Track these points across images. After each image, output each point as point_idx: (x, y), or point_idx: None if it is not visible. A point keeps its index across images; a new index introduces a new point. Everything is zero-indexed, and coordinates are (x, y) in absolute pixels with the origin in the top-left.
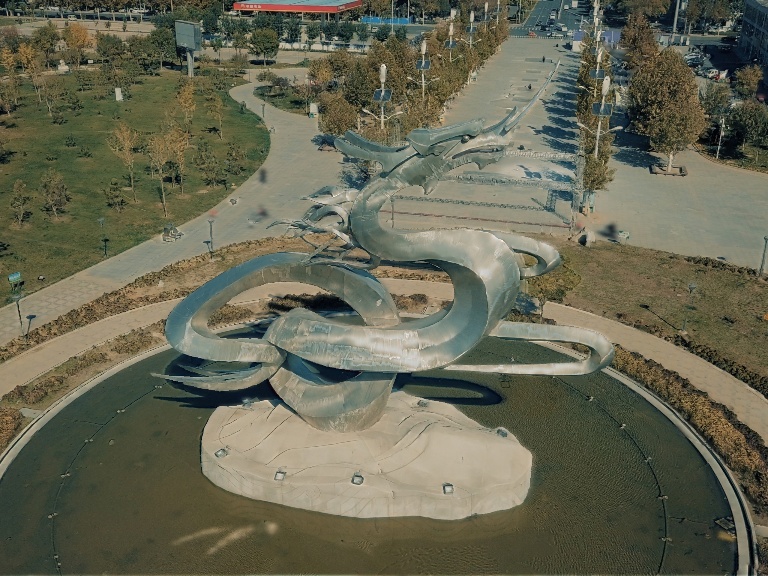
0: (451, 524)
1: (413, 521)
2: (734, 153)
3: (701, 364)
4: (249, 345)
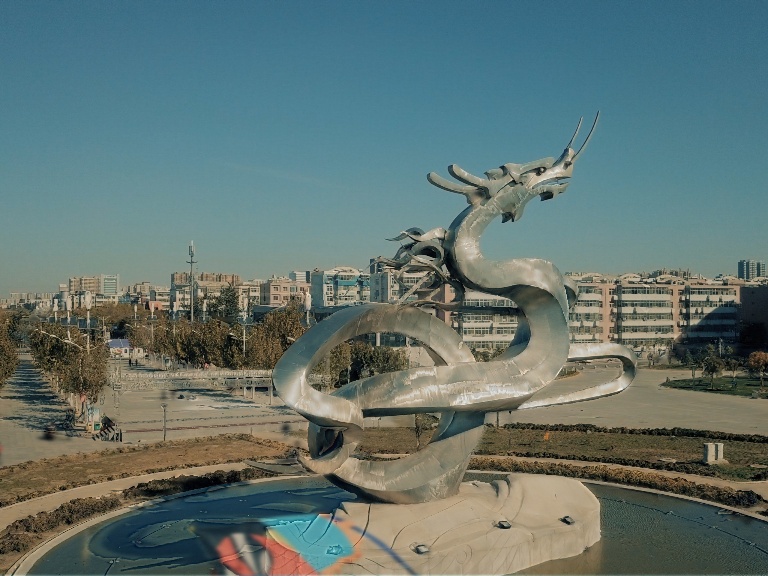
0: (577, 561)
1: (547, 568)
2: None
3: (554, 461)
4: (353, 405)
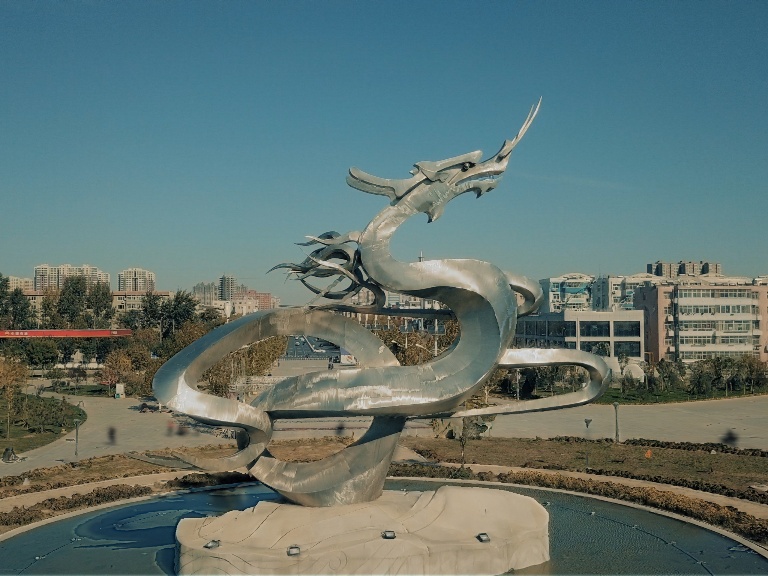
0: None
1: None
2: (531, 395)
3: (621, 480)
4: (245, 405)
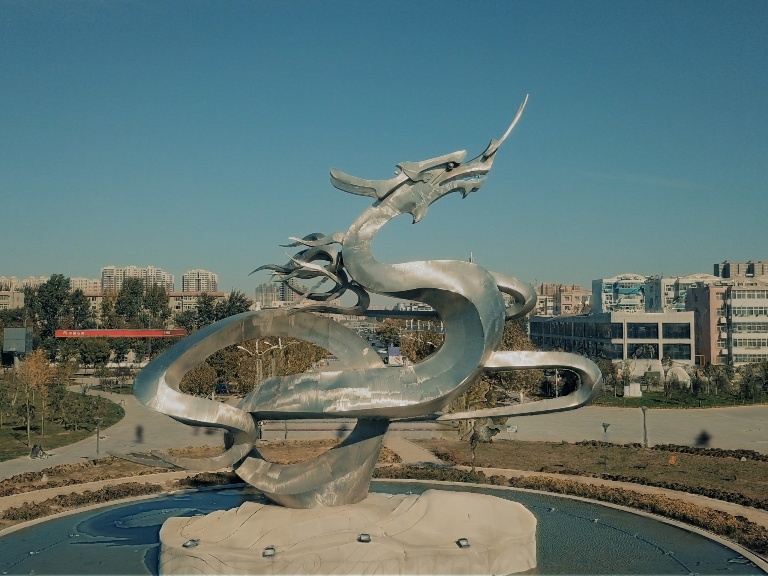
0: None
1: None
2: None
3: (637, 487)
4: (227, 406)
